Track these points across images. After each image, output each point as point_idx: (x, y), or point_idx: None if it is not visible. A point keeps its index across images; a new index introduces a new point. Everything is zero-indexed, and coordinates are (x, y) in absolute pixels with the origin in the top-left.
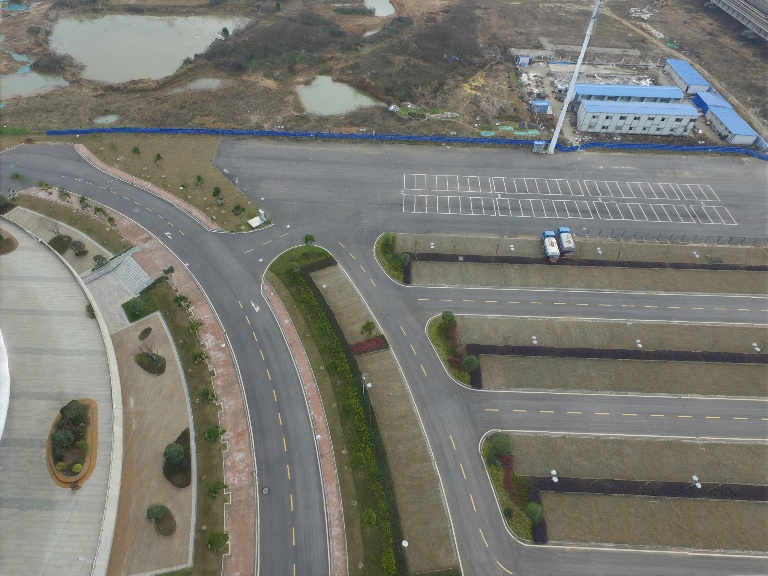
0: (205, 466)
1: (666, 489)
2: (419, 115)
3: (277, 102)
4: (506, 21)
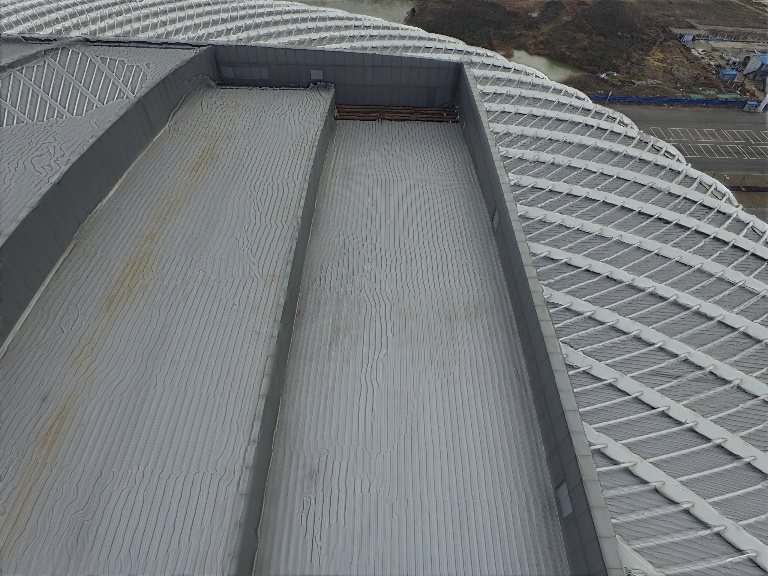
0: None
1: None
2: (629, 82)
3: None
4: (647, 5)
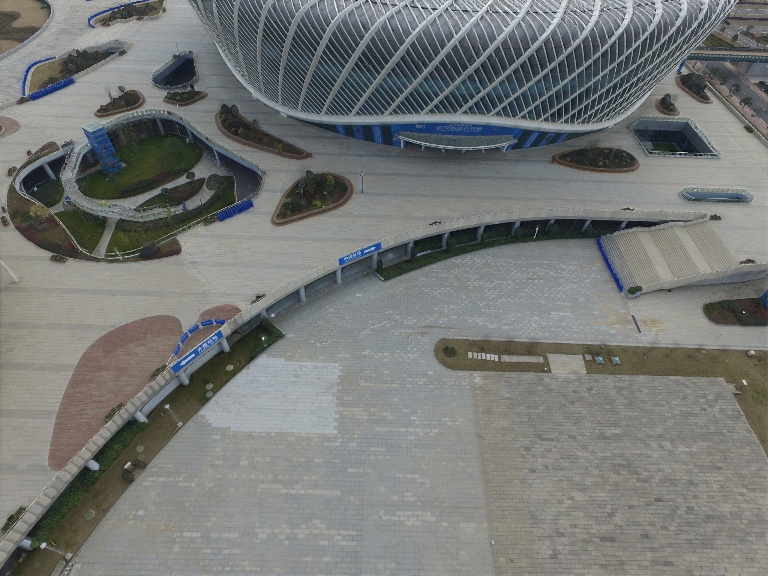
0: None
1: None
2: None
3: None
4: None
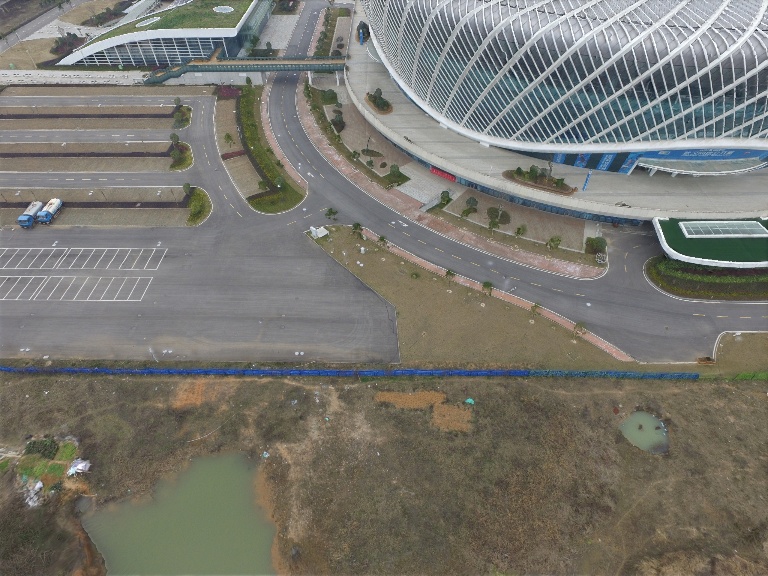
0: (325, 123)
1: (113, 114)
2: (39, 447)
3: (325, 500)
4: None
